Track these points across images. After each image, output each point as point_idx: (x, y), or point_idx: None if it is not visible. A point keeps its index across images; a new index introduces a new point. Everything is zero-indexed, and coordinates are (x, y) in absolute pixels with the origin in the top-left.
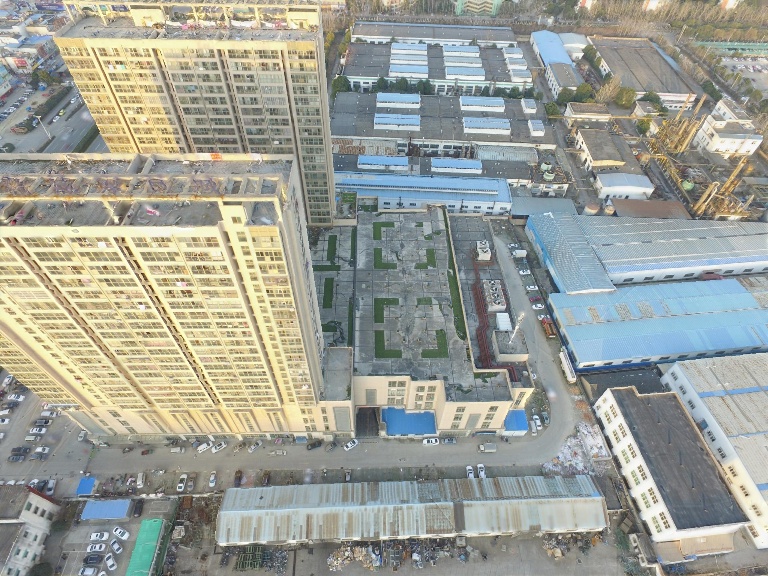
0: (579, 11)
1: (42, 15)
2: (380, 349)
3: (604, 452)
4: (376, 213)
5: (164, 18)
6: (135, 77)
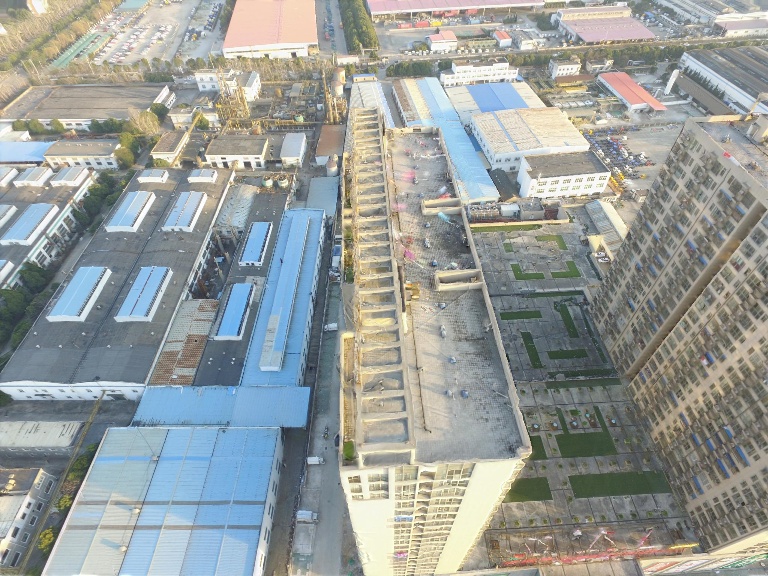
0: None
1: None
2: (571, 274)
3: None
4: None
5: None
6: None
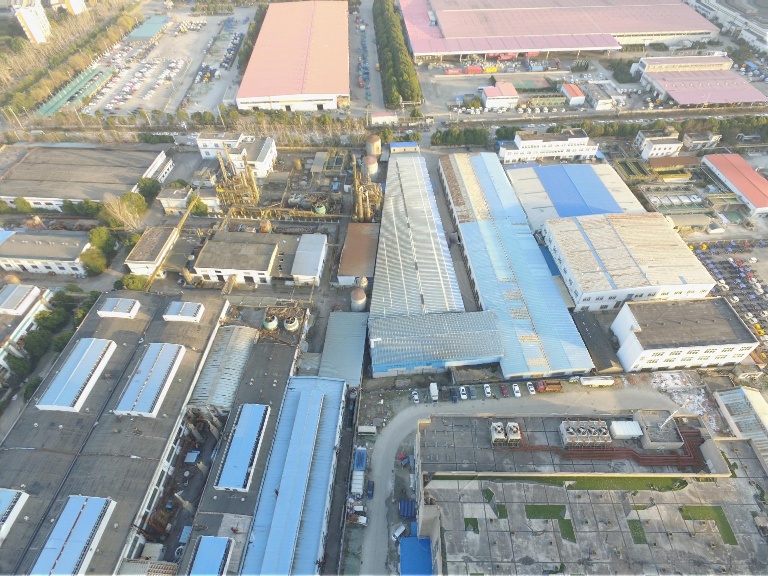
0: None
1: None
2: None
3: (677, 375)
4: None
5: None
6: None
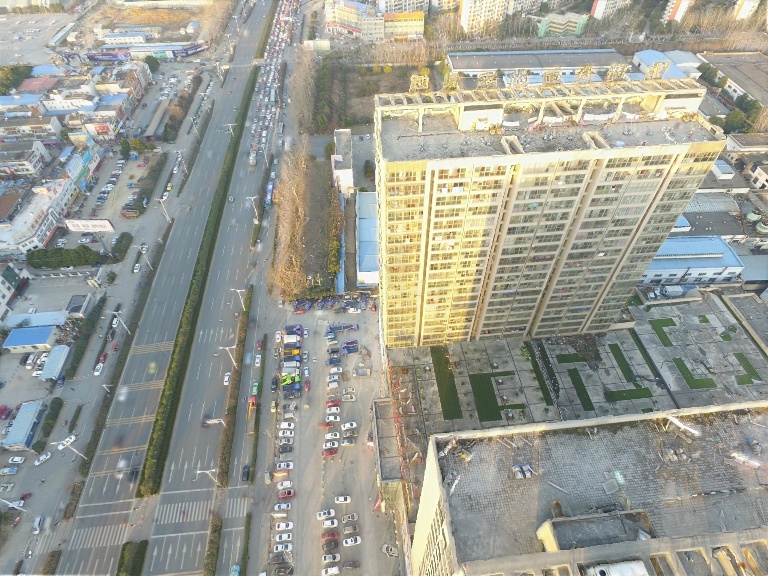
0: (674, 26)
1: (102, 68)
2: None
3: None
4: (643, 307)
5: (501, 118)
6: (469, 199)
